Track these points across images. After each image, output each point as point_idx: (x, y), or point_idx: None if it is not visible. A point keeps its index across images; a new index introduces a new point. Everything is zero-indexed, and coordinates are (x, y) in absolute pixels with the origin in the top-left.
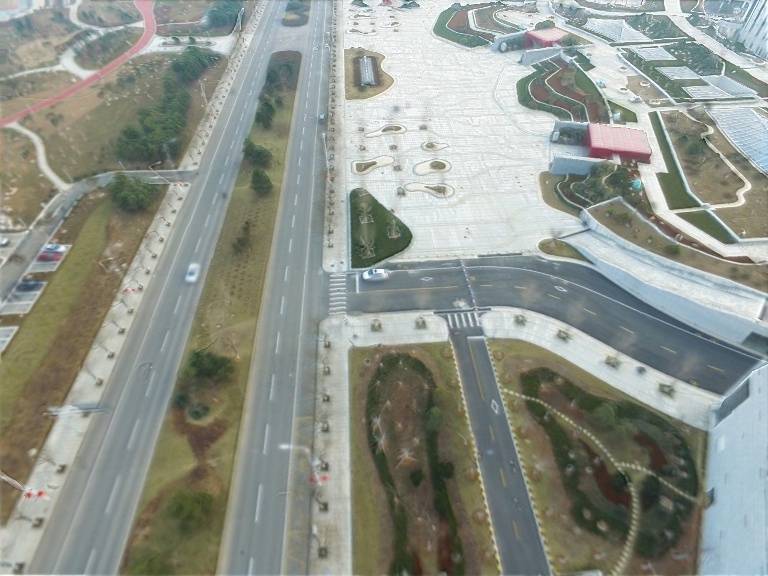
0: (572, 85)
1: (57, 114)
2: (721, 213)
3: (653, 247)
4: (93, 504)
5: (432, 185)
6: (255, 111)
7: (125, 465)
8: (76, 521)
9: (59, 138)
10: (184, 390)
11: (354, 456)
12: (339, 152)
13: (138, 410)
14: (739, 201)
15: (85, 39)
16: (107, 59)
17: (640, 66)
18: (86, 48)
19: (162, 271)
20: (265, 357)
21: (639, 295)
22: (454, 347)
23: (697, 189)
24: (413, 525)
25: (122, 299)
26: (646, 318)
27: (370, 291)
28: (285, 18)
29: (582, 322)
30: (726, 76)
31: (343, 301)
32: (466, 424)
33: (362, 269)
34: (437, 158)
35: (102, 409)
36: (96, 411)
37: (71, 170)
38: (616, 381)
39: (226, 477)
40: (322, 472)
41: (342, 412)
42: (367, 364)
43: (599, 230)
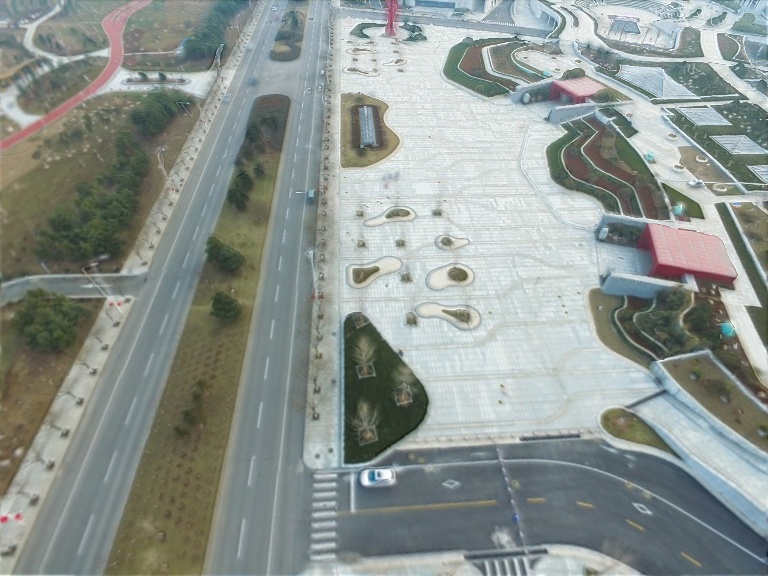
0: (616, 159)
1: None
2: None
3: None
4: None
5: (451, 307)
6: (228, 182)
7: None
8: None
9: None
10: None
11: None
12: (331, 249)
13: None
14: None
15: (34, 73)
16: (57, 100)
17: (692, 133)
18: (33, 85)
19: (73, 462)
20: None
21: (756, 526)
22: None
23: None
24: None
25: None
26: None
27: (370, 508)
28: (274, 50)
29: None
30: None
31: (331, 530)
32: None
33: (359, 465)
34: (456, 262)
35: None
36: None
37: None
38: None
39: None
40: None
41: None
42: None
43: (681, 397)
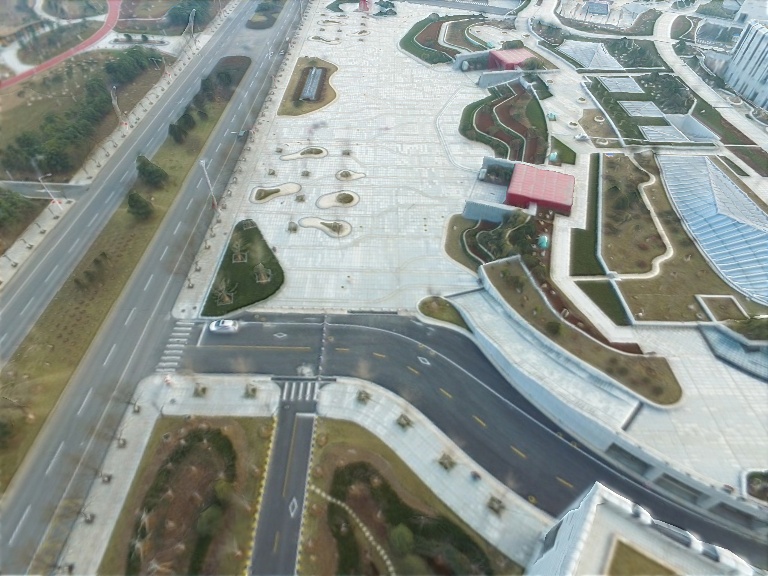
0: (518, 116)
1: None
2: (625, 285)
3: (536, 321)
4: None
5: (330, 221)
6: None
7: None
8: None
9: None
10: None
11: (107, 558)
12: (245, 175)
13: None
14: (652, 272)
15: (35, 31)
16: (50, 54)
17: (601, 98)
18: (32, 41)
19: (0, 302)
20: (63, 418)
21: (509, 377)
22: (277, 424)
23: (609, 253)
24: None
25: None
26: (507, 407)
27: (212, 345)
28: (251, 19)
29: (432, 406)
30: (692, 116)
31: (177, 355)
32: (250, 528)
33: (213, 318)
34: (347, 189)
35: None
36: None
37: None
38: (442, 488)
39: None
40: (62, 575)
41: (118, 498)
42: (166, 440)
43: (491, 291)
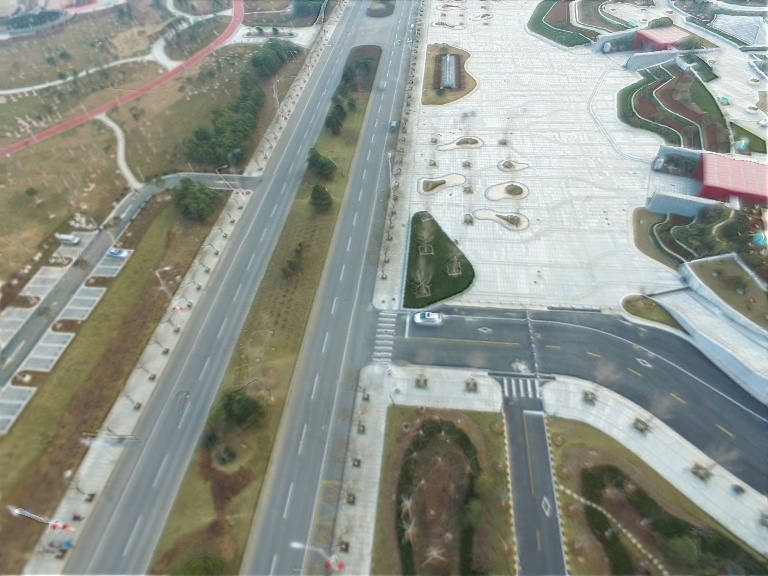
0: (686, 100)
1: (140, 108)
2: None
3: None
4: (113, 544)
5: (504, 214)
6: (326, 113)
7: (148, 505)
8: (95, 560)
9: (139, 133)
10: (213, 433)
11: (378, 540)
12: (407, 166)
13: (169, 444)
14: None
15: (176, 28)
16: (194, 50)
17: None
18: (176, 38)
19: (213, 288)
20: (300, 402)
21: (745, 385)
22: (506, 421)
23: None
24: None
25: (169, 318)
26: (752, 418)
27: (420, 337)
28: (370, 8)
29: (667, 411)
30: None
31: (389, 346)
32: (509, 523)
33: (414, 310)
34: (514, 181)
35: (136, 437)
36: (130, 438)
37: (144, 169)
38: (703, 499)
39: (242, 539)
40: (341, 554)
41: (371, 483)
42: (405, 429)
43: (701, 291)
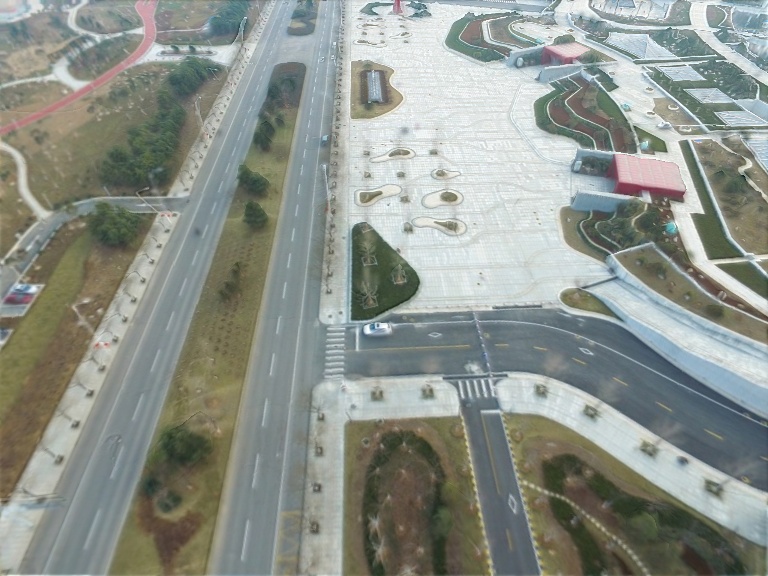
0: (595, 108)
1: (42, 131)
2: (767, 266)
3: (692, 305)
4: None
5: (442, 220)
6: (254, 130)
7: (79, 571)
8: None
9: (43, 157)
10: (153, 477)
11: (347, 567)
12: (342, 179)
13: (100, 497)
14: None
15: (80, 47)
16: (102, 69)
17: (667, 87)
18: (81, 56)
19: (141, 318)
20: (249, 431)
21: (676, 362)
22: (465, 423)
23: (738, 235)
24: None
25: (92, 355)
26: (685, 392)
27: (371, 349)
28: (290, 26)
29: (612, 395)
30: (761, 100)
31: (341, 361)
32: (479, 527)
33: (363, 321)
34: (448, 188)
35: (59, 494)
36: (52, 497)
37: (52, 196)
38: (654, 475)
39: None
40: None
41: (335, 507)
42: (365, 445)
43: (628, 279)
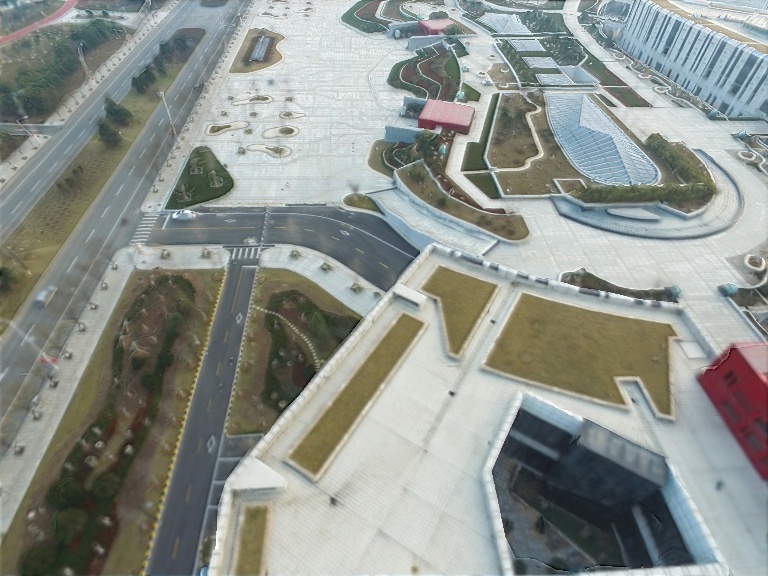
0: (437, 68)
1: None
2: (501, 175)
3: (431, 200)
4: None
5: (273, 147)
6: None
7: None
8: None
9: None
10: None
11: (98, 349)
12: (201, 116)
13: None
14: (524, 166)
15: None
16: (16, 27)
17: (508, 55)
18: None
19: None
20: (55, 275)
21: (409, 239)
22: (227, 273)
23: (493, 156)
24: (122, 398)
25: None
26: (406, 257)
27: (174, 228)
28: None
29: (348, 258)
30: (582, 67)
31: (146, 235)
32: (207, 330)
33: (175, 210)
34: (289, 125)
35: None
36: None
37: None
38: (351, 302)
39: None
40: (64, 360)
41: (103, 317)
42: (139, 282)
43: (401, 188)
